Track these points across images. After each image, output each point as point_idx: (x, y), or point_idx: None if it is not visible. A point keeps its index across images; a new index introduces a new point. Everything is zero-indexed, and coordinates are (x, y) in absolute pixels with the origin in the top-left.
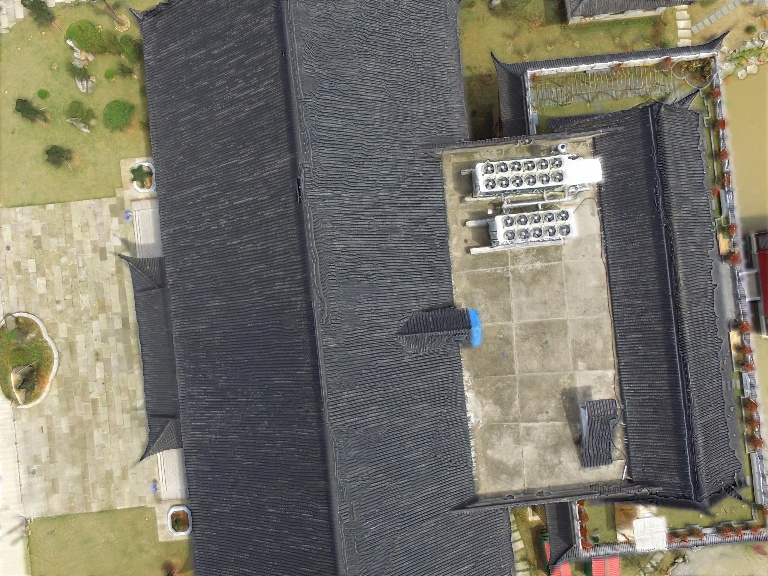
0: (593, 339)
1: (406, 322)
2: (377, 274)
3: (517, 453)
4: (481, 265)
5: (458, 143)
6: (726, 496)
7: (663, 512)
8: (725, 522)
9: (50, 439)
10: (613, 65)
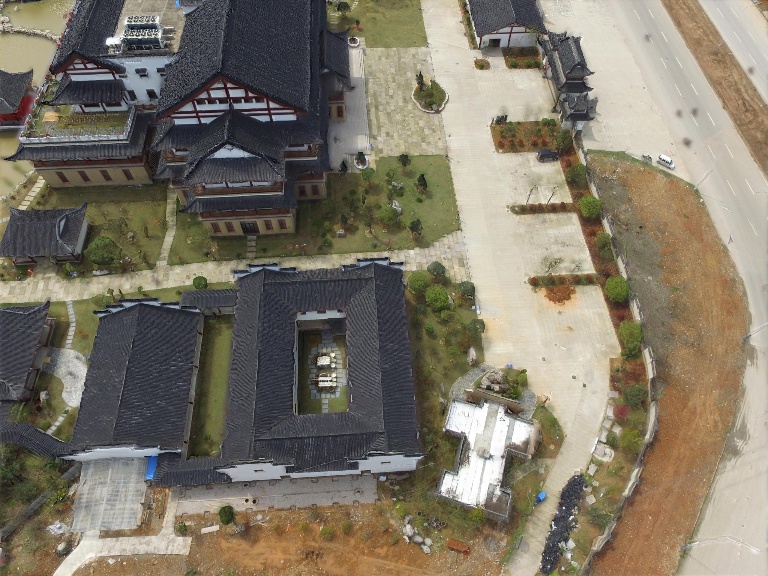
0: (132, 7)
1: None
2: None
3: None
4: None
5: (167, 55)
6: None
7: None
8: None
9: (417, 71)
10: (77, 138)
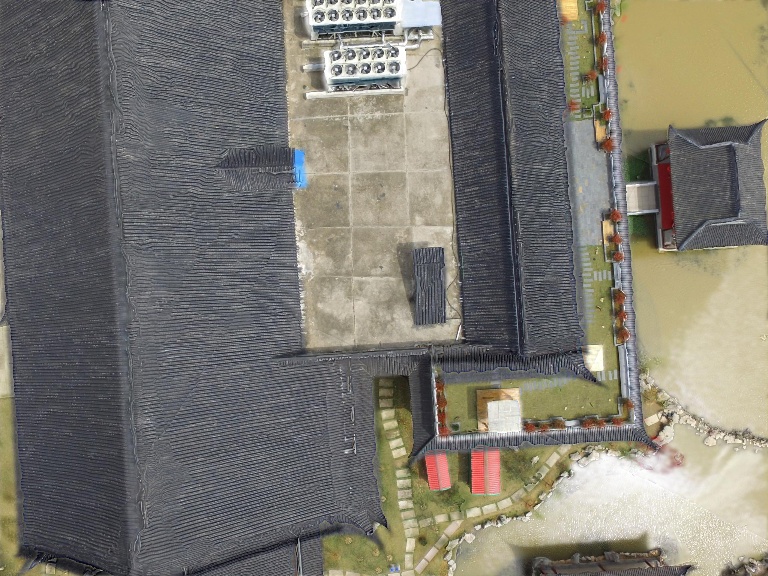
0: (432, 194)
1: (227, 156)
2: (195, 102)
3: (348, 308)
4: (319, 113)
5: None
6: (592, 389)
7: (527, 403)
8: (590, 415)
9: None
10: None
